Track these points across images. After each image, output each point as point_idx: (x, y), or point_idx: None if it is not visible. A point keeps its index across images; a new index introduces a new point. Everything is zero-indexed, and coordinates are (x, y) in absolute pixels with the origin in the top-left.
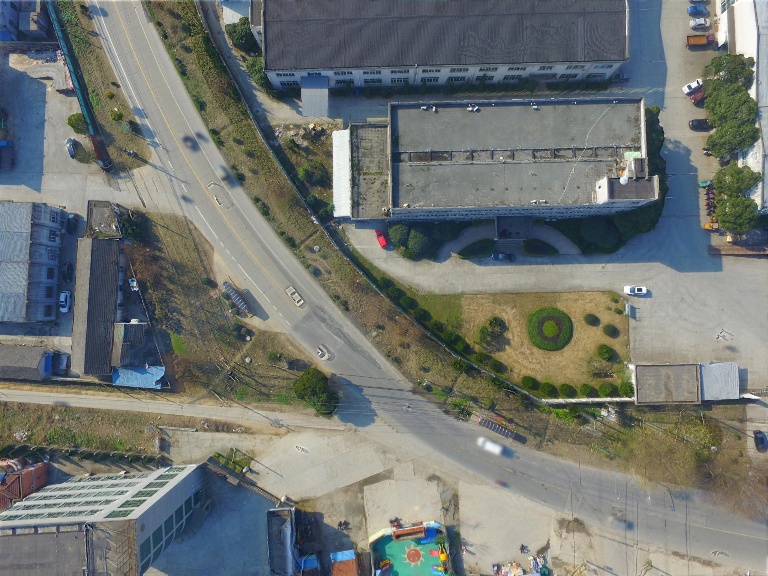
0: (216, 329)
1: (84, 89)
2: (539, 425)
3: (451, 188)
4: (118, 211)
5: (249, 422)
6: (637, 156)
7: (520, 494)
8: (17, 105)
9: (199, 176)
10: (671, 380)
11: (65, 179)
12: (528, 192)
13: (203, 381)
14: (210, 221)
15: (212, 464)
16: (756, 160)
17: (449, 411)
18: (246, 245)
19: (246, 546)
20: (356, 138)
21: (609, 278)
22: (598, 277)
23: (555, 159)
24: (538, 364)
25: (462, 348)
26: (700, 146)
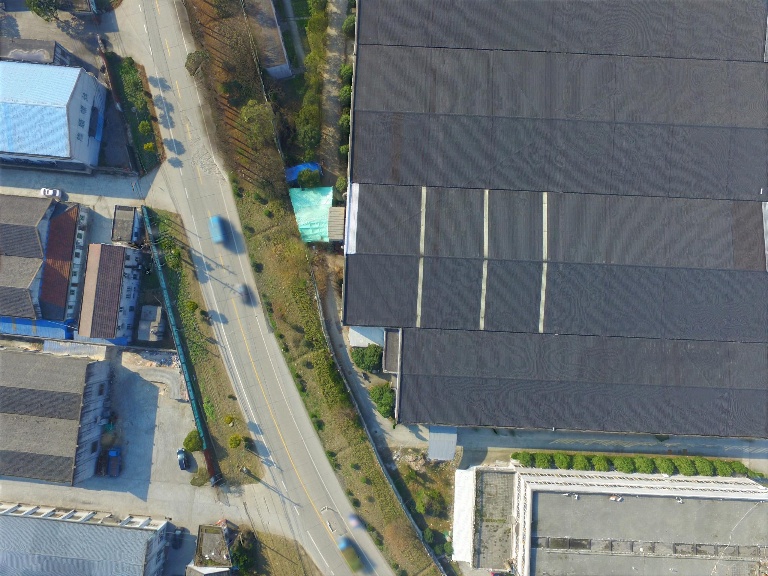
0: None
1: (198, 396)
2: None
3: None
4: (227, 529)
5: None
6: None
7: None
8: (127, 407)
9: (313, 499)
10: None
11: (173, 489)
12: None
13: None
14: (322, 548)
15: None
16: None
17: None
18: (357, 575)
19: None
20: (481, 482)
21: None
22: None
23: (697, 555)
24: None
25: None
26: None
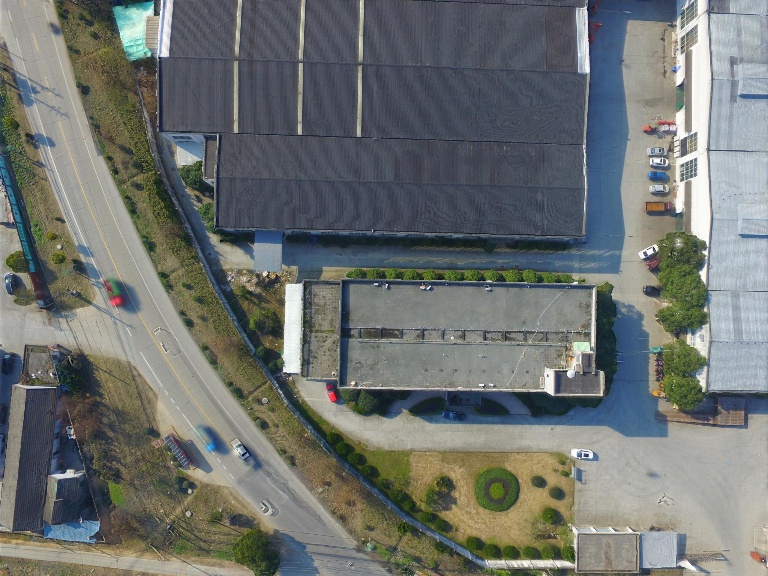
0: (157, 480)
1: (27, 221)
2: None
3: (400, 367)
4: (58, 353)
5: None
6: (586, 347)
7: None
8: None
9: (145, 320)
10: (611, 549)
11: (2, 315)
12: (477, 374)
13: (141, 533)
14: (155, 368)
15: None
16: (703, 343)
17: (392, 570)
18: (192, 394)
19: None
20: (309, 294)
21: (557, 440)
22: (547, 438)
23: (506, 342)
24: (483, 524)
25: (408, 509)
26: (653, 311)
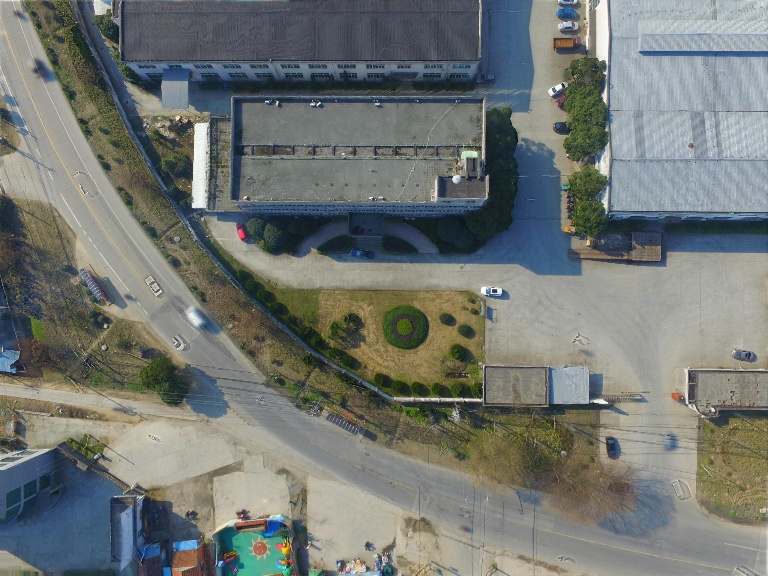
0: (75, 316)
1: None
2: (389, 423)
3: (291, 182)
4: None
5: (103, 409)
6: (473, 156)
7: (368, 491)
8: None
9: (66, 164)
10: (520, 382)
11: None
12: (367, 188)
13: (60, 367)
14: (74, 209)
15: (63, 449)
16: (605, 164)
17: (301, 405)
18: (108, 234)
19: (95, 532)
20: (216, 131)
21: (467, 278)
22: (456, 277)
23: (396, 156)
24: (392, 362)
25: (314, 343)
26: (564, 149)
